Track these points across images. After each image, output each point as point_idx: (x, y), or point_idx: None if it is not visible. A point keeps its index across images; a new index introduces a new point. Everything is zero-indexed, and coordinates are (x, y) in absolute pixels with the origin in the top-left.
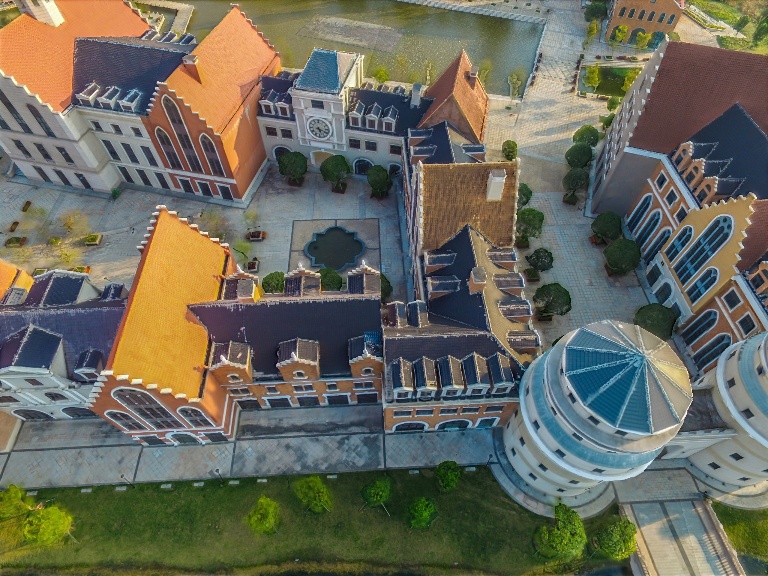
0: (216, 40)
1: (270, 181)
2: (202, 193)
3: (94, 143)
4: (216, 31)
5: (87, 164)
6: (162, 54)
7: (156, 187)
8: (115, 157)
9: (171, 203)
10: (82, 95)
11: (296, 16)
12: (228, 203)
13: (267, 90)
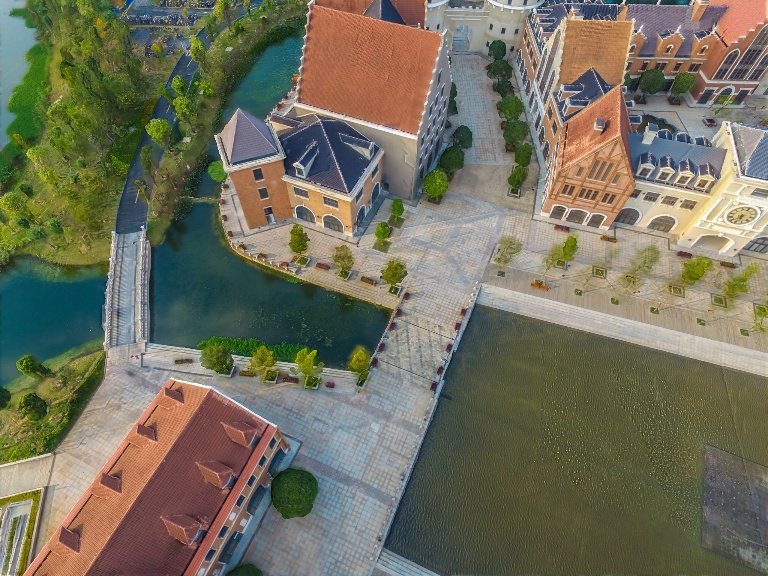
0: None
1: None
2: None
3: None
4: None
5: None
6: None
7: None
8: None
9: None
10: None
11: None
12: None
13: None
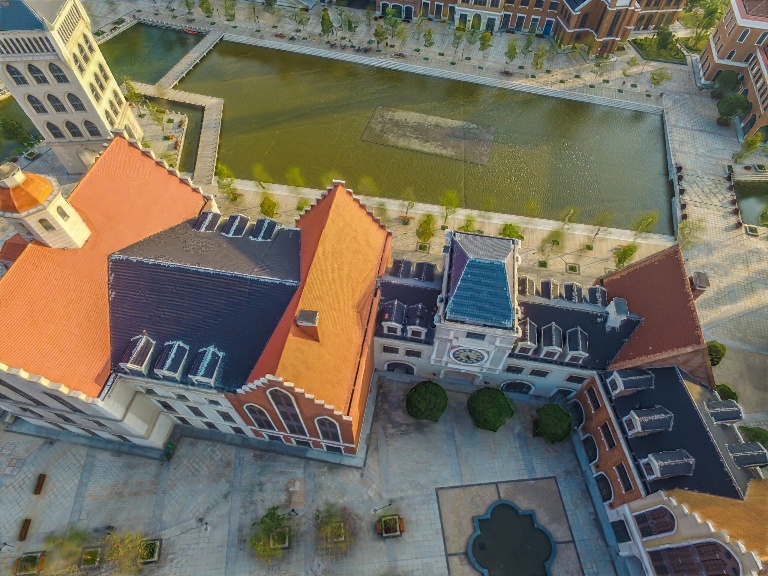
0: (326, 253)
1: (385, 409)
2: (296, 443)
3: (142, 405)
4: (324, 237)
5: (132, 432)
6: (249, 285)
7: (226, 432)
8: (170, 409)
9: (253, 463)
10: (131, 366)
11: (354, 110)
12: (335, 458)
13: (388, 300)
